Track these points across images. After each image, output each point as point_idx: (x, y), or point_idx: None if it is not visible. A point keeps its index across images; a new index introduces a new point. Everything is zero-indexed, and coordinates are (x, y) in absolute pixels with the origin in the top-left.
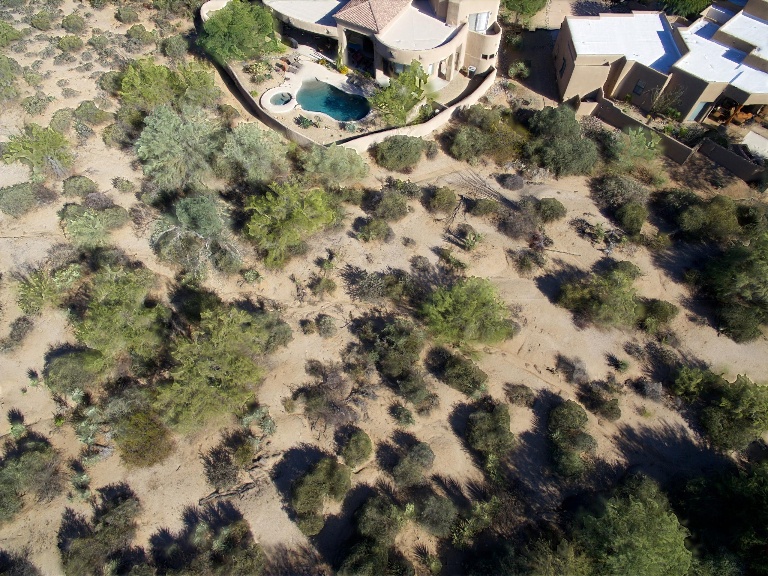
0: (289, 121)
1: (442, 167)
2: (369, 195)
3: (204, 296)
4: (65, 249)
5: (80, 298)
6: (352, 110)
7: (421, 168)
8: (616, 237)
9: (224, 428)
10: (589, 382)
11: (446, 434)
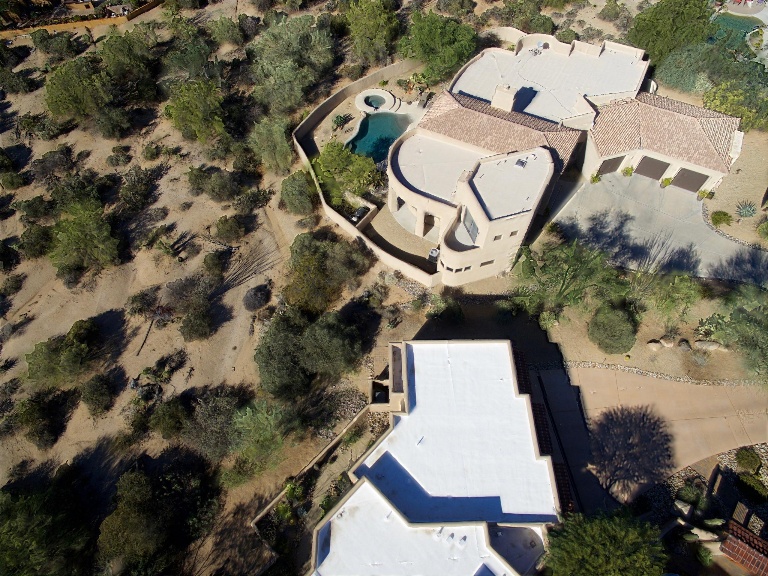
0: (346, 111)
1: (287, 235)
2: (252, 178)
3: (151, 87)
4: (216, 25)
5: (178, 42)
6: (376, 159)
7: (286, 217)
8: (147, 395)
9: (59, 118)
10: (3, 343)
11: (5, 234)
